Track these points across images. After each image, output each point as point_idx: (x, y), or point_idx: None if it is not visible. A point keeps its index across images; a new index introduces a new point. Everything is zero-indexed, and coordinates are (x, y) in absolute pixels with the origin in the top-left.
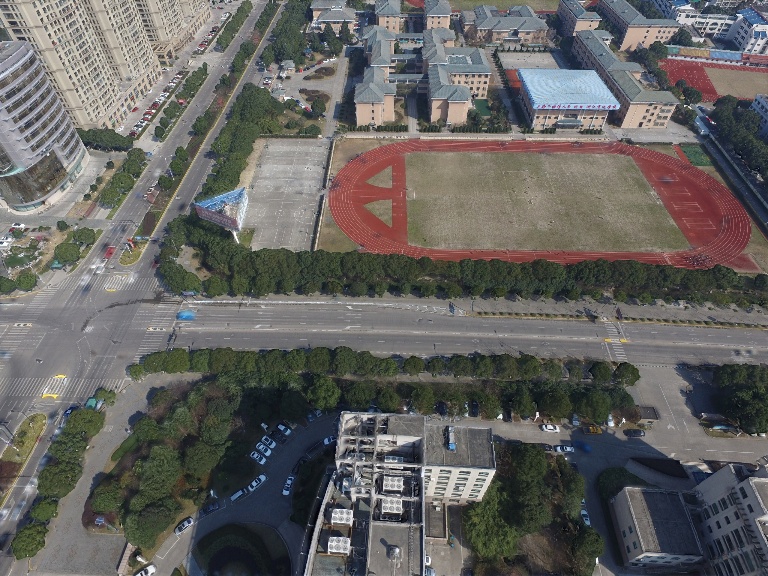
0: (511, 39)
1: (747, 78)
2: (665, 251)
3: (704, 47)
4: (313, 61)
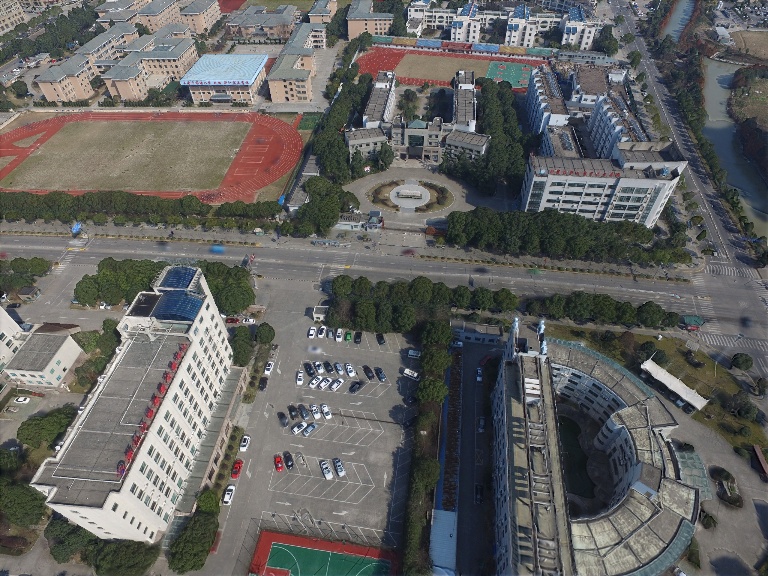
0: (258, 33)
1: (433, 62)
2: (193, 190)
3: (428, 37)
4: (73, 54)
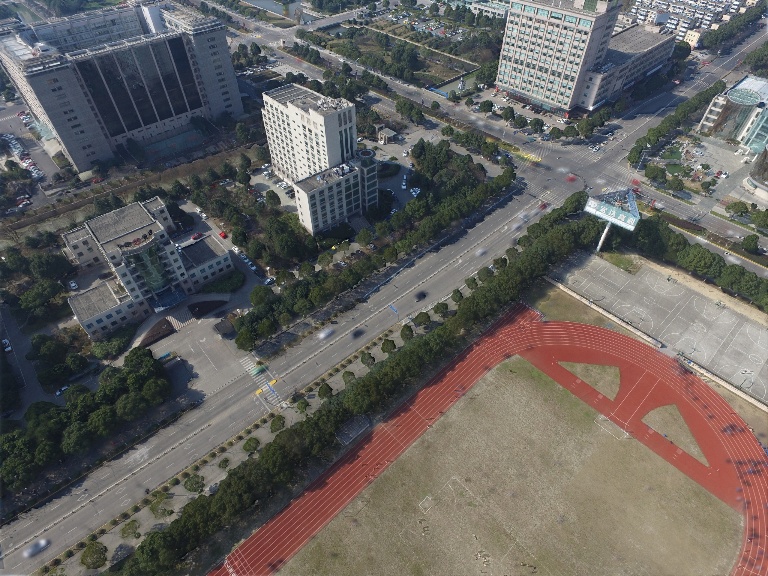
0: None
1: None
2: None
3: None
4: None
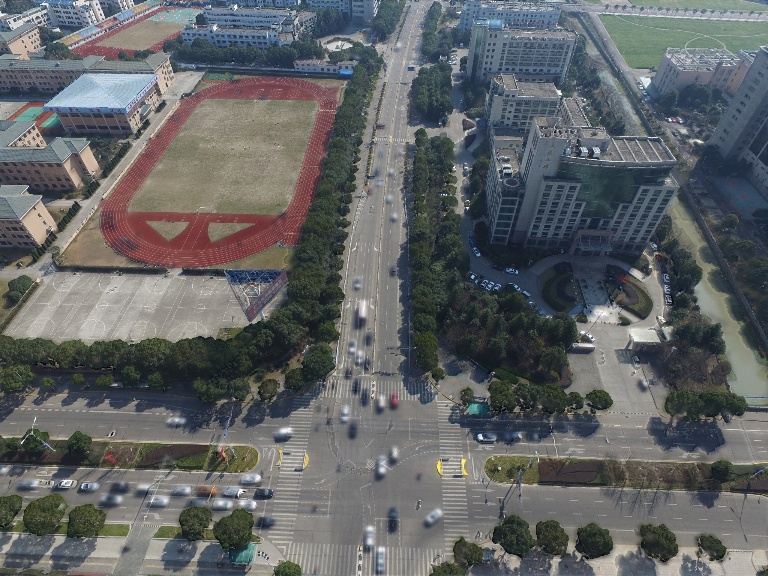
0: None
1: (127, 36)
2: (317, 109)
3: None
4: None
